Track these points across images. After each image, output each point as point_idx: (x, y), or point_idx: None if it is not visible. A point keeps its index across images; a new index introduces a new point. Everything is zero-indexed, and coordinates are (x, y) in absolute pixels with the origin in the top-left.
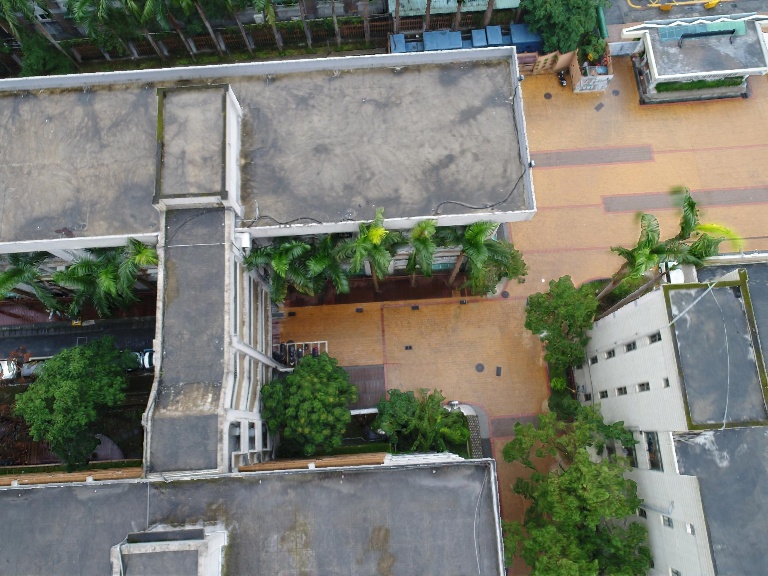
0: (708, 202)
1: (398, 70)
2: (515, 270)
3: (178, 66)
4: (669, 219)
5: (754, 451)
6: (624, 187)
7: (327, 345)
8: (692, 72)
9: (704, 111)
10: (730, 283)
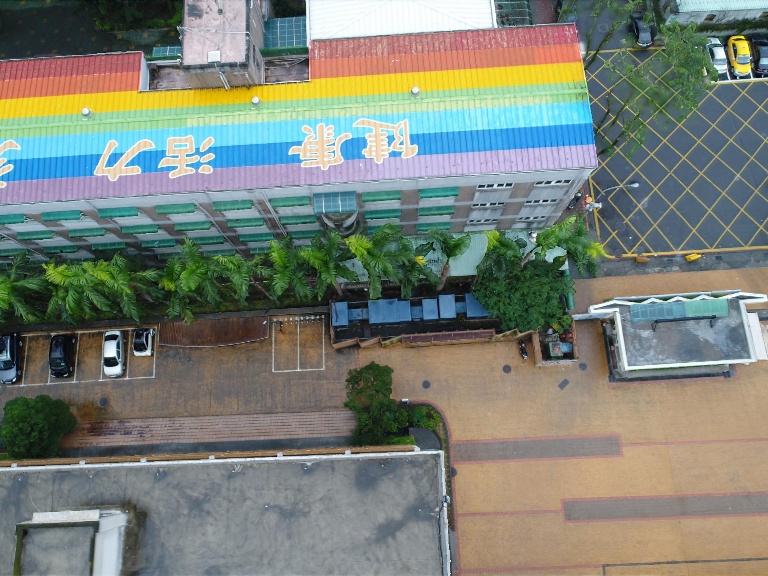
0: (681, 512)
1: (309, 466)
2: None
3: (101, 322)
4: (636, 532)
5: None
6: (587, 489)
7: None
8: (666, 362)
9: (681, 393)
10: None
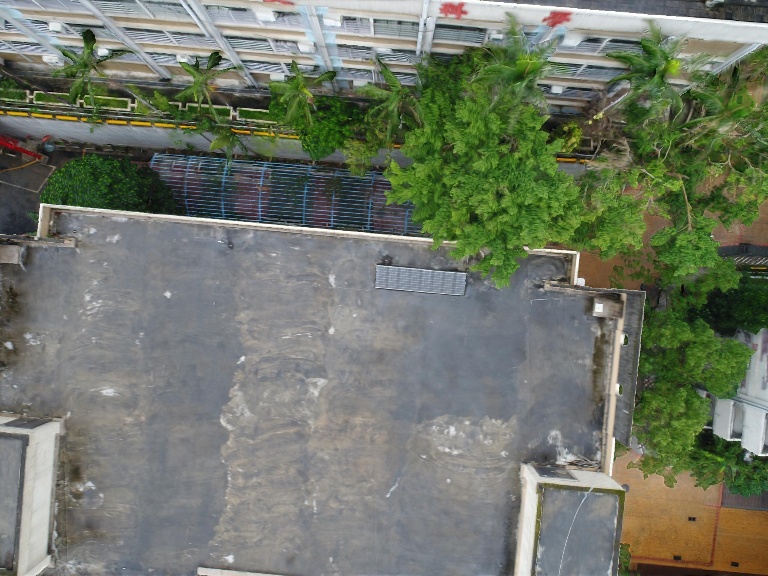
0: None
1: None
2: None
3: None
4: None
5: (523, 440)
6: None
7: None
8: None
9: None
10: None
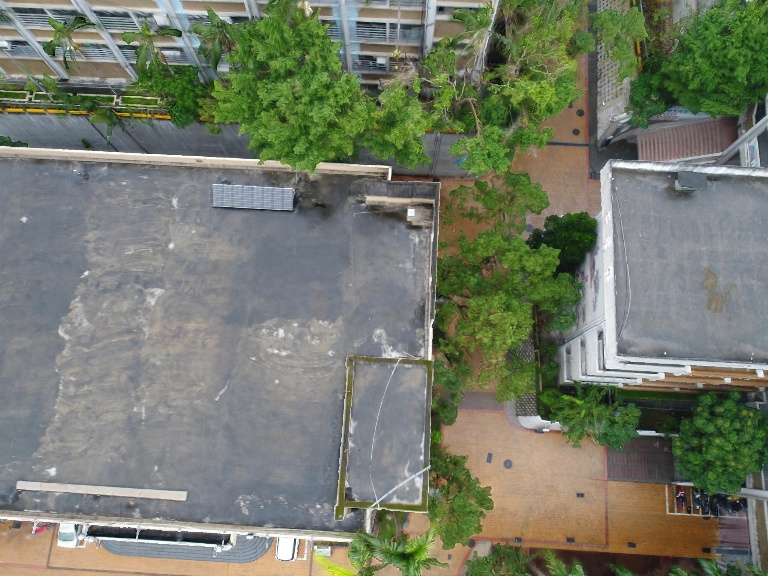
0: None
1: None
2: (485, 567)
3: None
4: None
5: (349, 339)
6: None
7: (667, 509)
8: None
9: None
10: (355, 505)
